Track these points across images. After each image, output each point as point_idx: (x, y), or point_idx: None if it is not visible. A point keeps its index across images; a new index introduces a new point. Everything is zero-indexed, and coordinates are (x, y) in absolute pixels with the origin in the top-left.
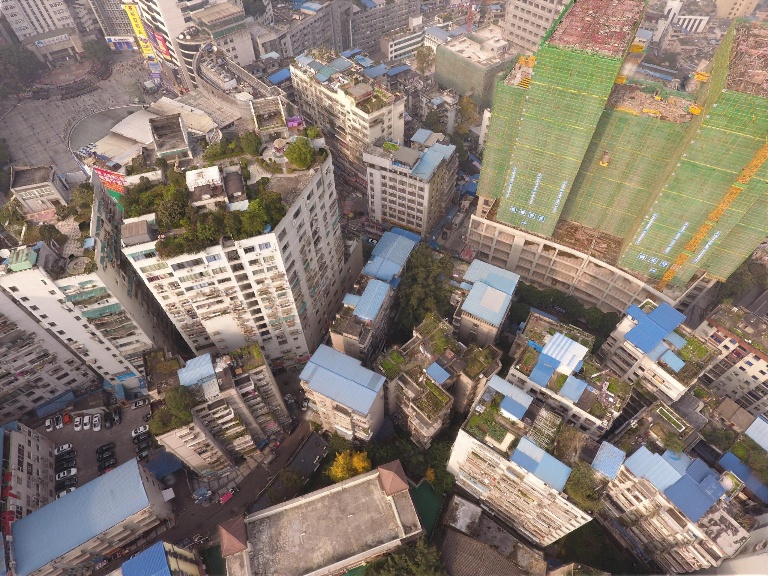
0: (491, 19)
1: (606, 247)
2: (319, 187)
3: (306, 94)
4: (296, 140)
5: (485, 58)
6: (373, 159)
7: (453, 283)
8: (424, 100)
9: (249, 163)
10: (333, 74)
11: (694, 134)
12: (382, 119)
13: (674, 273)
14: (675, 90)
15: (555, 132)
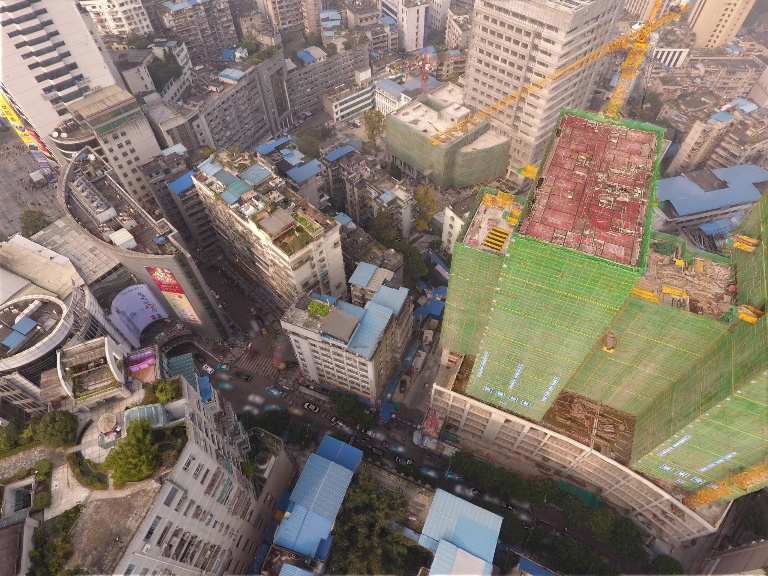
0: (450, 66)
1: (613, 431)
2: (173, 498)
3: (215, 210)
4: (129, 426)
5: (444, 131)
6: (295, 329)
7: (409, 534)
8: (372, 192)
9: (57, 462)
10: (244, 193)
11: (755, 370)
12: (310, 256)
13: (714, 499)
14: (703, 251)
15: (541, 329)
